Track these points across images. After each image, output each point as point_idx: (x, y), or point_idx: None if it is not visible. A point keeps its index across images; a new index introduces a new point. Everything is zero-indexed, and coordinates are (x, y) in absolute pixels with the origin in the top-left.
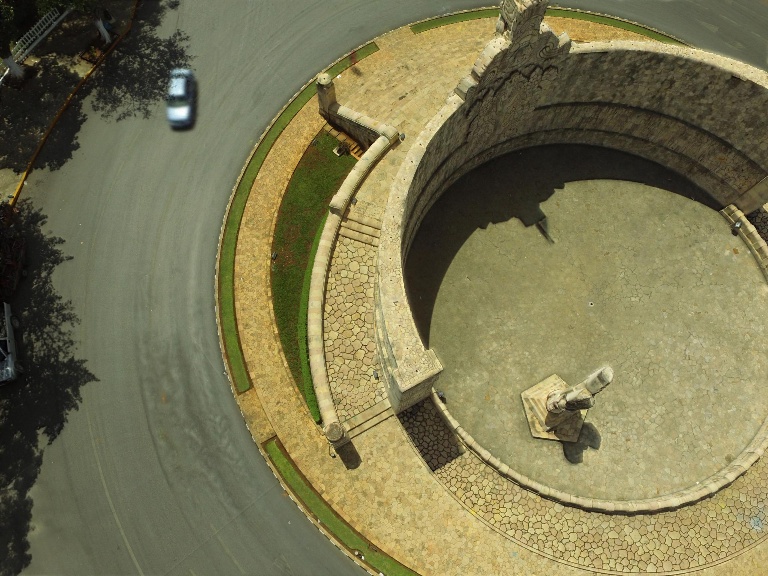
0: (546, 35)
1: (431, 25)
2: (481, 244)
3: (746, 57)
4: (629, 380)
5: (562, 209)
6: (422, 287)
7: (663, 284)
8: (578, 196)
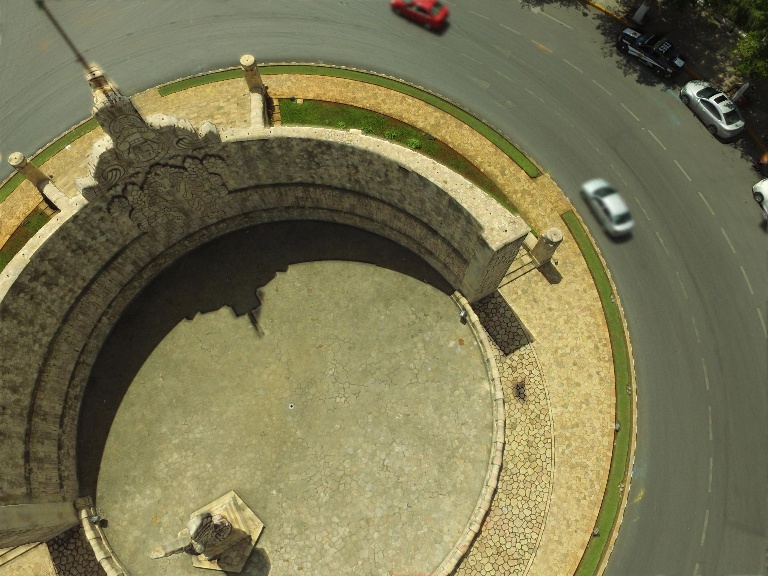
0: (168, 129)
1: (181, 86)
2: (184, 337)
3: (514, 117)
4: (315, 496)
5: (280, 295)
6: (109, 389)
7: (374, 382)
8: (301, 280)
